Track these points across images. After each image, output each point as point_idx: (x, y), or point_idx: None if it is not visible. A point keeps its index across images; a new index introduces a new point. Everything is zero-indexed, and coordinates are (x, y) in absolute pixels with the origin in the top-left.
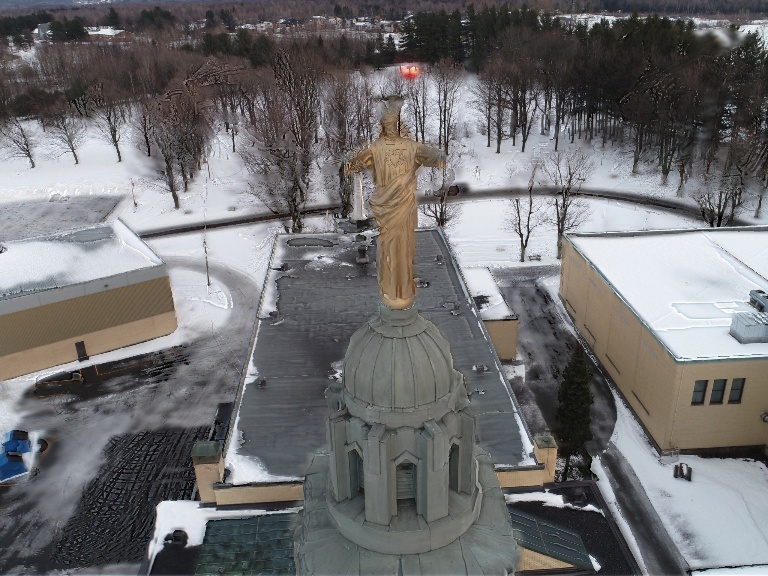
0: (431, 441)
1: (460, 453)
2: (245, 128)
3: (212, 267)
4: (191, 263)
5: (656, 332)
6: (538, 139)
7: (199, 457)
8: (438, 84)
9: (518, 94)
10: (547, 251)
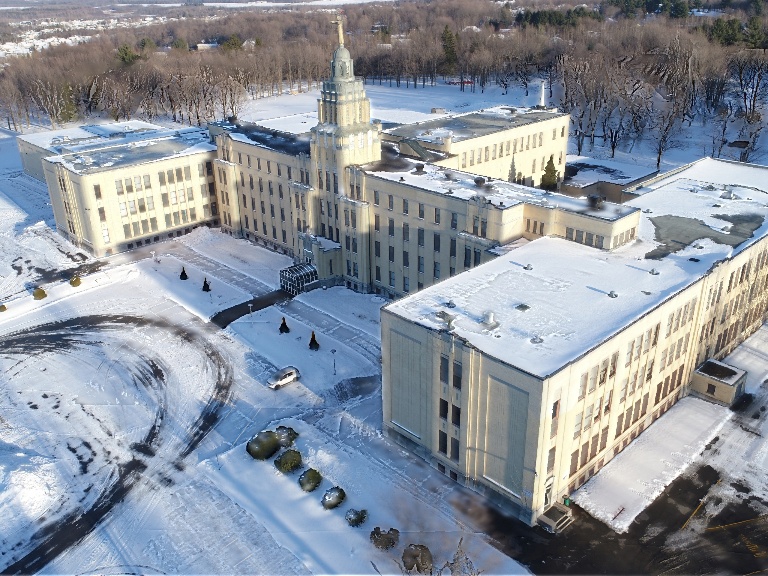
0: None
1: None
2: (659, 87)
3: None
4: None
5: None
6: None
7: (374, 121)
8: None
9: None
10: None
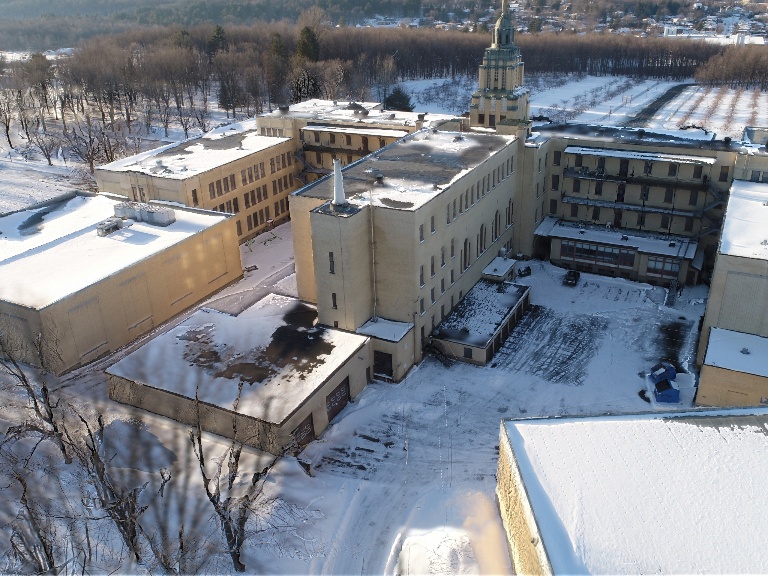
0: None
1: None
2: None
3: None
4: None
5: None
6: None
7: None
8: None
9: None
10: None
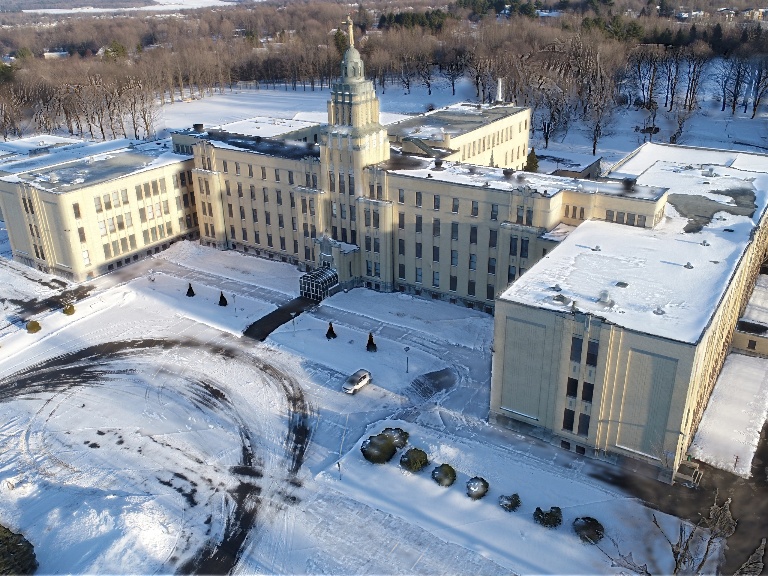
0: (348, 63)
1: (355, 69)
2: (558, 82)
3: None
4: None
5: (615, 172)
6: (766, 109)
7: None
8: (689, 59)
9: (755, 72)
10: None
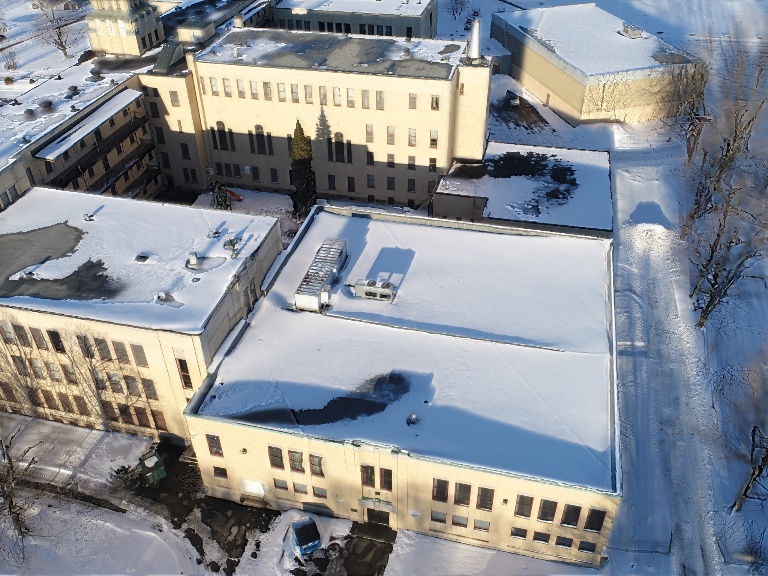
0: None
1: None
2: None
3: (714, 143)
4: (725, 135)
5: (368, 220)
6: None
7: None
8: None
9: None
10: (727, 324)
